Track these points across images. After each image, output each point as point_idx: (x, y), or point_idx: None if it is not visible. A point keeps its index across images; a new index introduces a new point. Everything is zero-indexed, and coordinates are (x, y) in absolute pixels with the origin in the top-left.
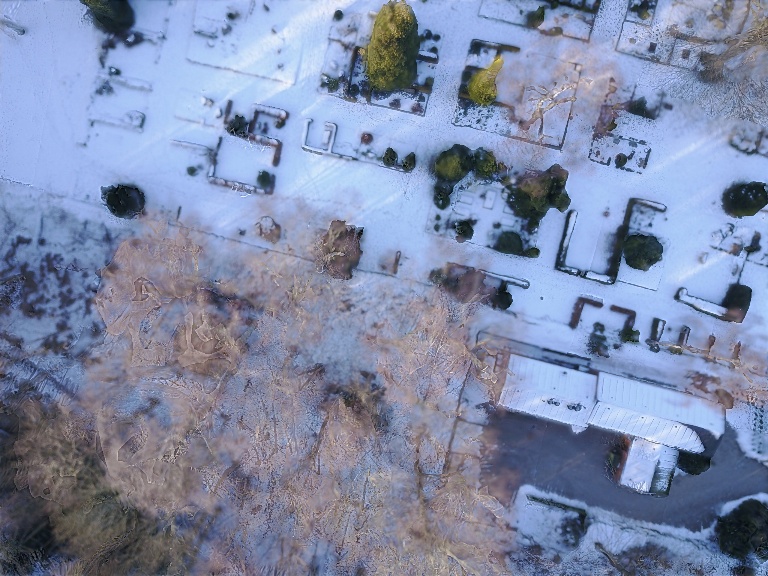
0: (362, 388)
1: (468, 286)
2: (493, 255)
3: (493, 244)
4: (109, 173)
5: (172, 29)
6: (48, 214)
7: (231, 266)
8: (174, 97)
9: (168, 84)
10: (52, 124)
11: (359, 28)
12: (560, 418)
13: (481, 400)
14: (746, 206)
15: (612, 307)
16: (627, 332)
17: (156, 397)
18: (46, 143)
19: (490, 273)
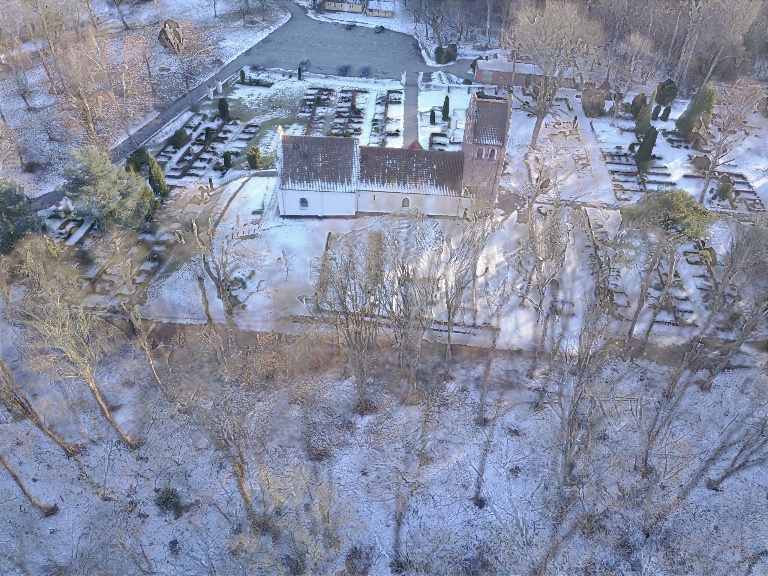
0: None
1: None
2: None
3: None
4: None
5: None
6: None
7: None
8: None
9: None
10: None
11: None
12: None
13: None
14: None
15: None
16: None
17: (719, 4)
18: None
19: None
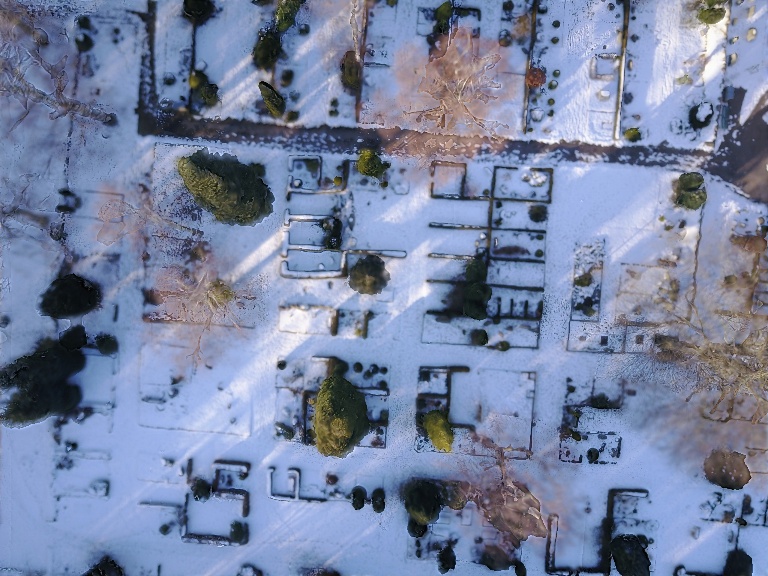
0: None
1: None
2: (480, 568)
3: (478, 560)
4: (83, 543)
5: (120, 396)
6: None
7: None
8: (134, 460)
9: (126, 449)
10: (19, 505)
11: (304, 373)
12: None
13: None
14: (729, 485)
15: None
16: None
17: None
18: (16, 524)
19: None
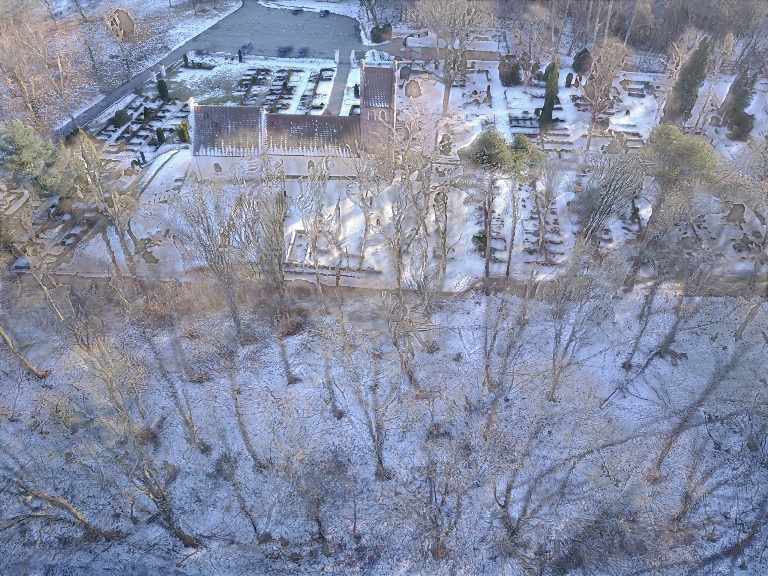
0: None
1: None
2: None
3: None
4: None
5: None
6: None
7: None
8: None
9: None
10: None
11: None
12: None
13: None
14: None
15: None
16: None
17: None
18: None
19: None
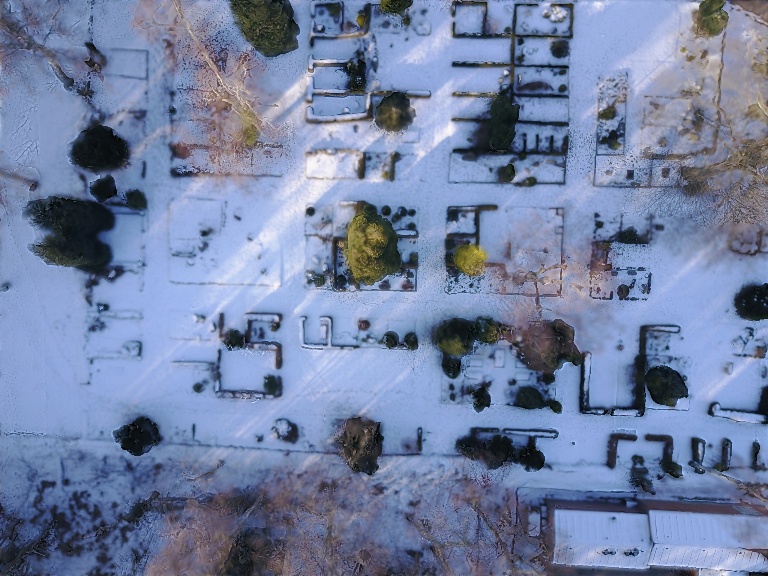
0: (412, 567)
1: (497, 457)
2: (515, 411)
3: (512, 401)
4: (118, 405)
5: (150, 254)
6: (67, 456)
7: (256, 473)
8: (166, 319)
9: (157, 308)
10: (53, 369)
11: (333, 219)
12: (619, 565)
13: (534, 554)
14: (762, 313)
15: (647, 437)
16: (668, 465)
17: None
18: (51, 389)
19: (516, 431)
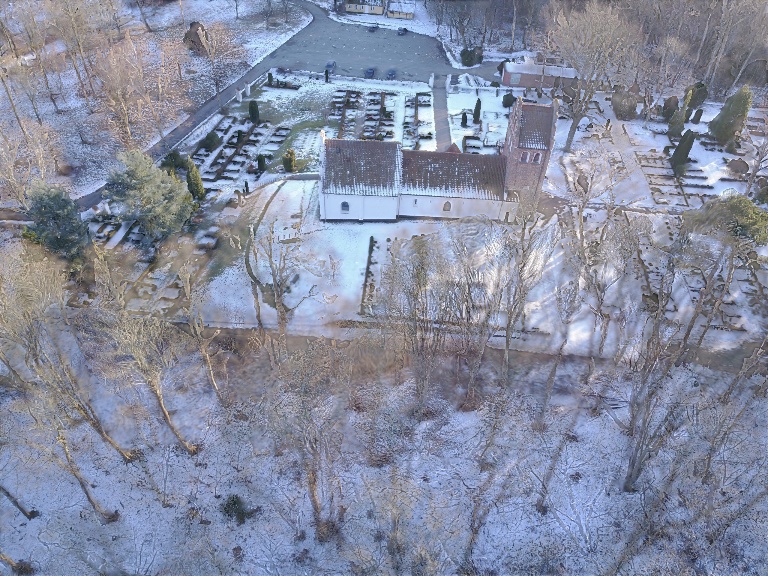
0: None
1: None
2: None
3: None
4: None
5: None
6: None
7: None
8: None
9: None
10: None
11: None
12: None
13: None
14: None
15: None
16: None
17: (749, 7)
18: None
19: None
